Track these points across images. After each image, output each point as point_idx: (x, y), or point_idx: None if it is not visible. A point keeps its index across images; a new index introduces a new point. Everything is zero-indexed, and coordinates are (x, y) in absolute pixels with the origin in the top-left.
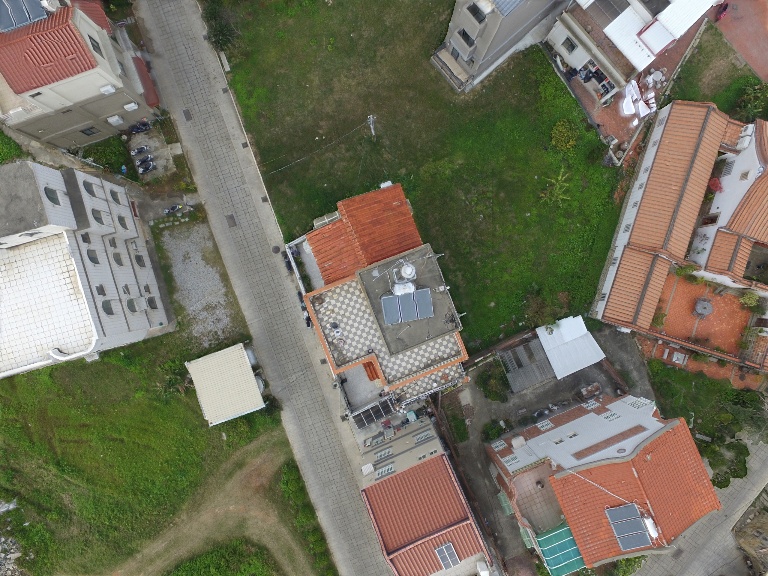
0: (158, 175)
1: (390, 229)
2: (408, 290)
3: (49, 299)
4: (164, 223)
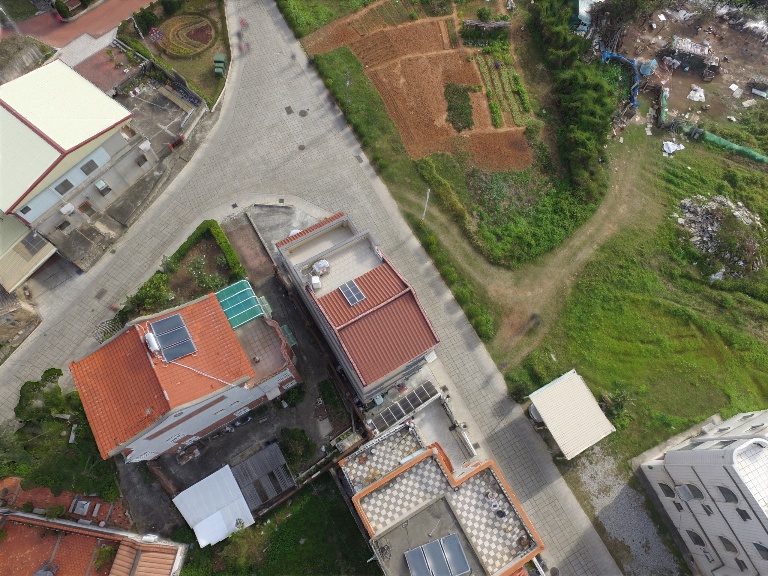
0: None
1: None
2: None
3: None
4: None
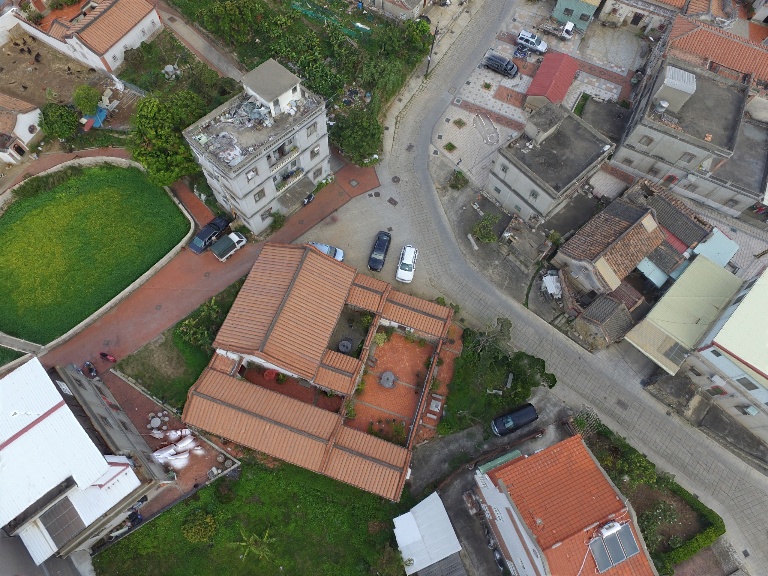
0: None
1: None
2: None
3: None
4: None
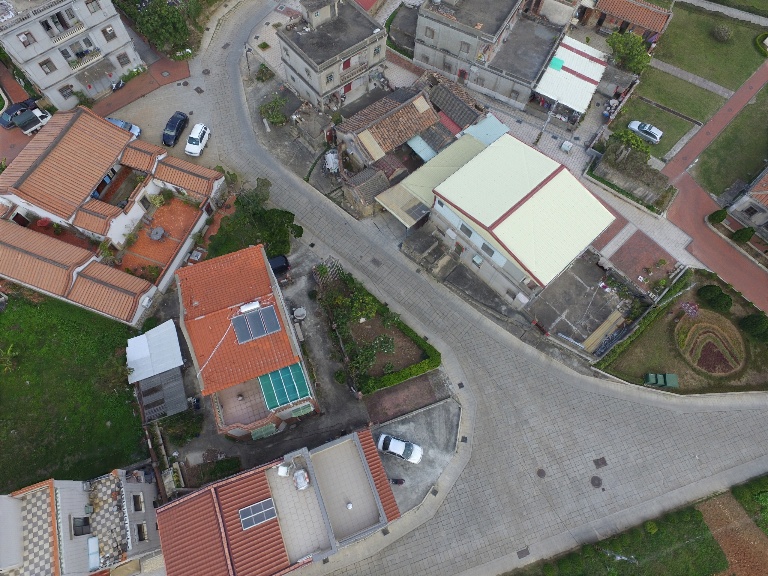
0: None
1: None
2: None
3: None
4: None
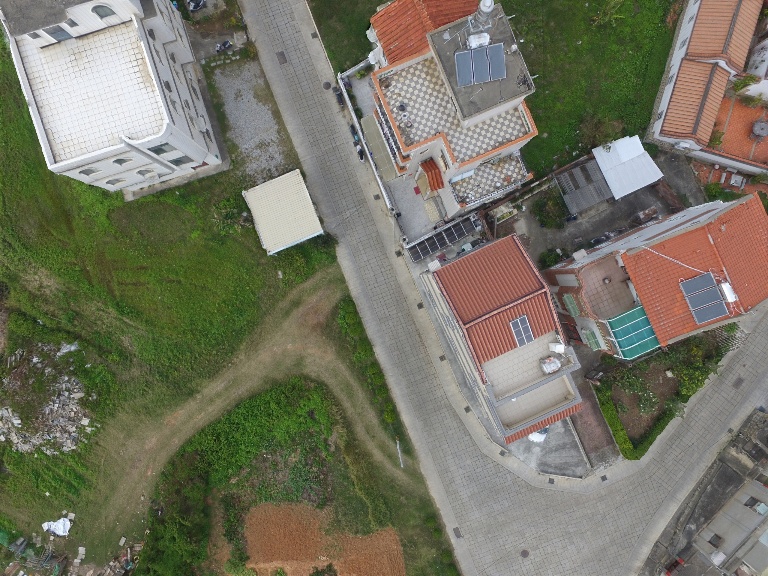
0: (208, 13)
1: (456, 5)
2: (483, 40)
3: (119, 88)
4: (215, 61)
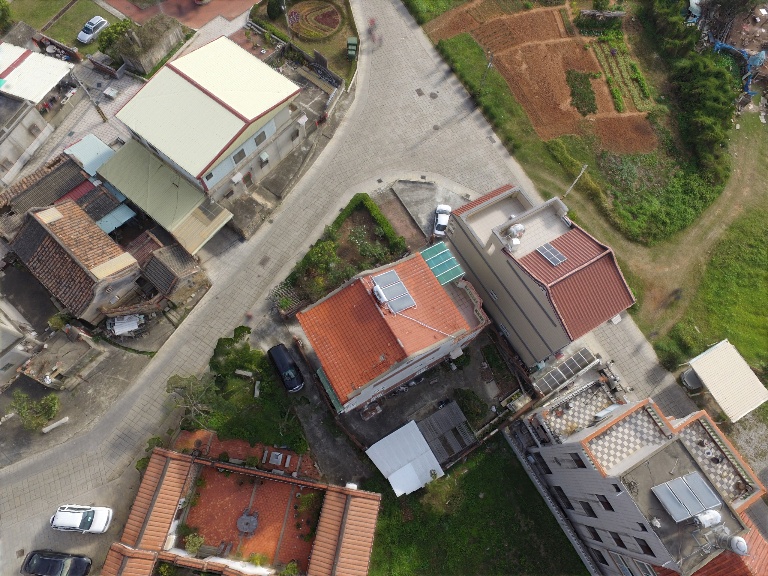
0: None
1: None
2: (706, 518)
3: None
4: None
